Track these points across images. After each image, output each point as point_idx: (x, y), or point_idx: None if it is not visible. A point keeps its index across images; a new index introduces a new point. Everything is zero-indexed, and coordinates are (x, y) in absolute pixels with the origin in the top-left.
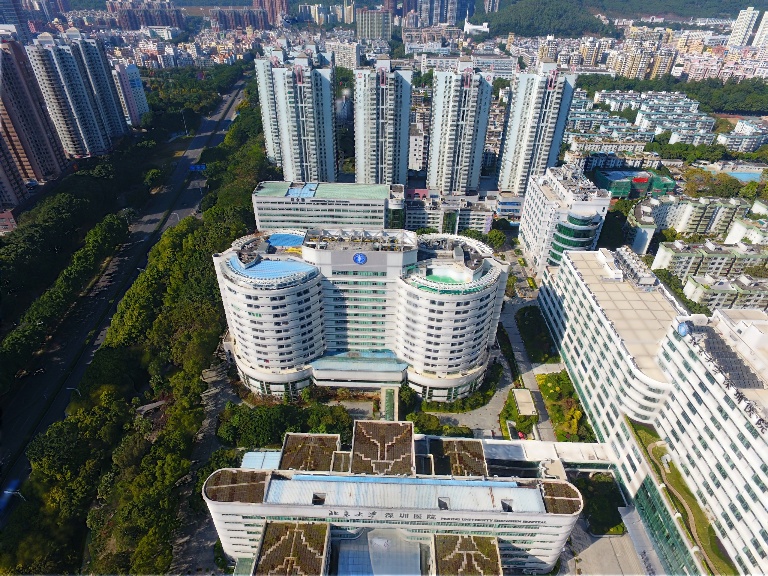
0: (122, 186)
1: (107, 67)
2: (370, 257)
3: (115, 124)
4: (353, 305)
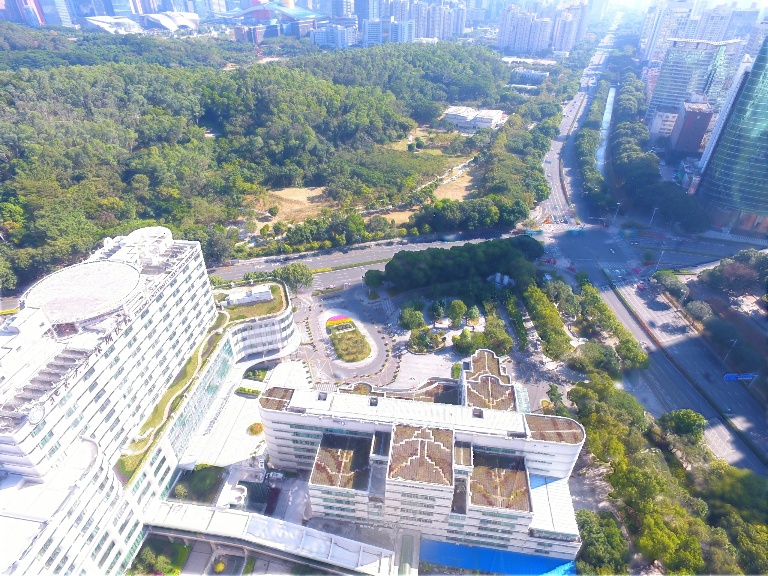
0: None
1: None
2: None
3: None
4: None
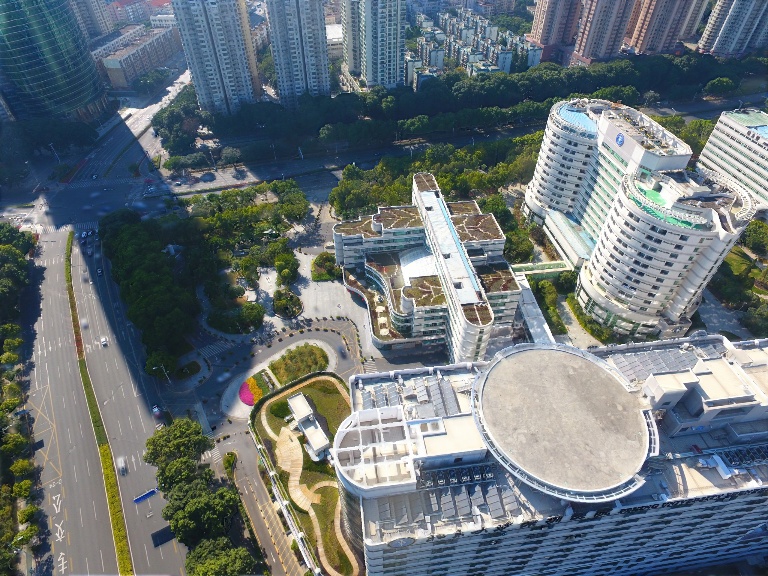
0: (689, 82)
1: None
2: (626, 142)
3: None
4: (600, 183)
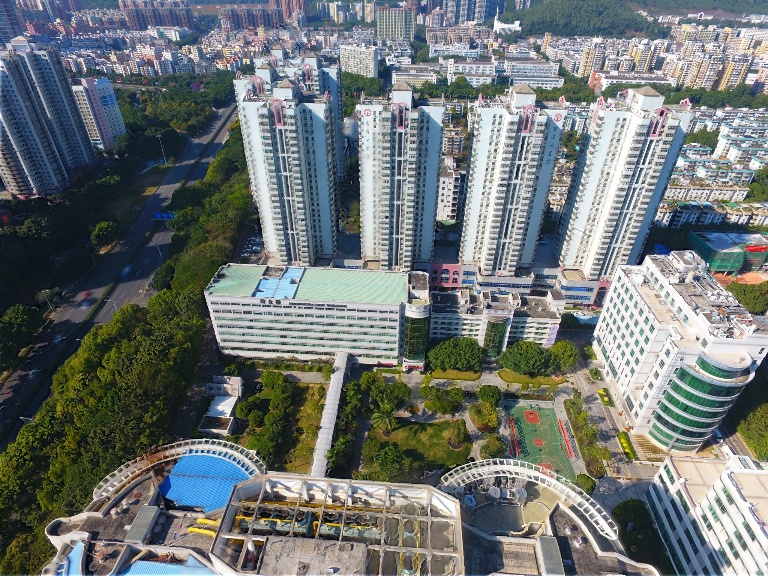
0: (62, 244)
1: (64, 84)
2: None
3: (77, 152)
4: None
